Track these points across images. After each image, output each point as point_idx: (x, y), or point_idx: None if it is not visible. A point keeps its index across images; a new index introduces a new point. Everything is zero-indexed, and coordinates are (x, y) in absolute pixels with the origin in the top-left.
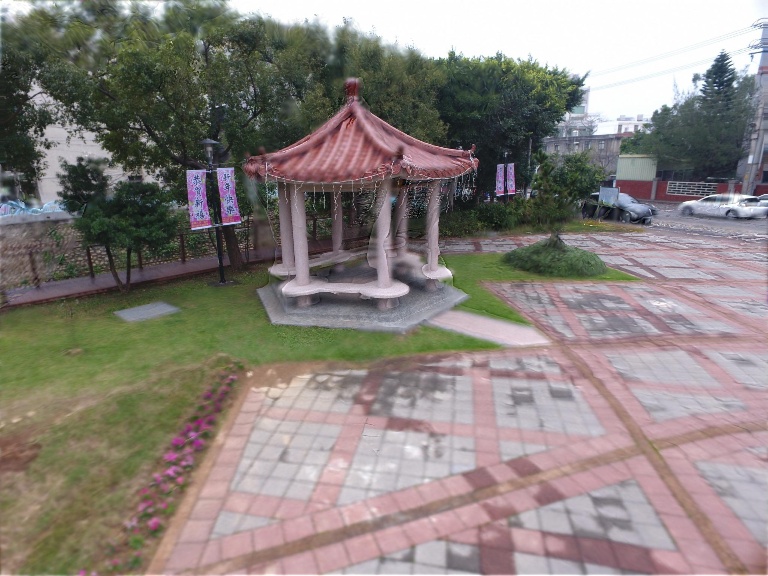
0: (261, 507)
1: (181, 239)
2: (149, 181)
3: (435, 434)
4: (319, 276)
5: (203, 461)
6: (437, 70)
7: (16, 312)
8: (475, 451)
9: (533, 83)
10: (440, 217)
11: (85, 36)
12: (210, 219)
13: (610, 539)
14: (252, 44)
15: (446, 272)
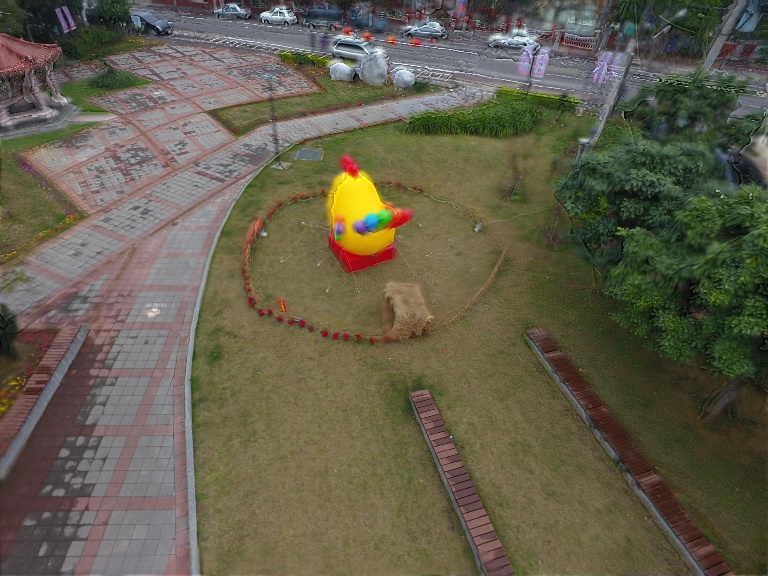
0: None
1: None
2: None
3: (91, 146)
4: (5, 112)
5: (31, 166)
6: None
7: None
8: None
9: None
10: None
11: None
12: None
13: None
14: None
15: (62, 98)
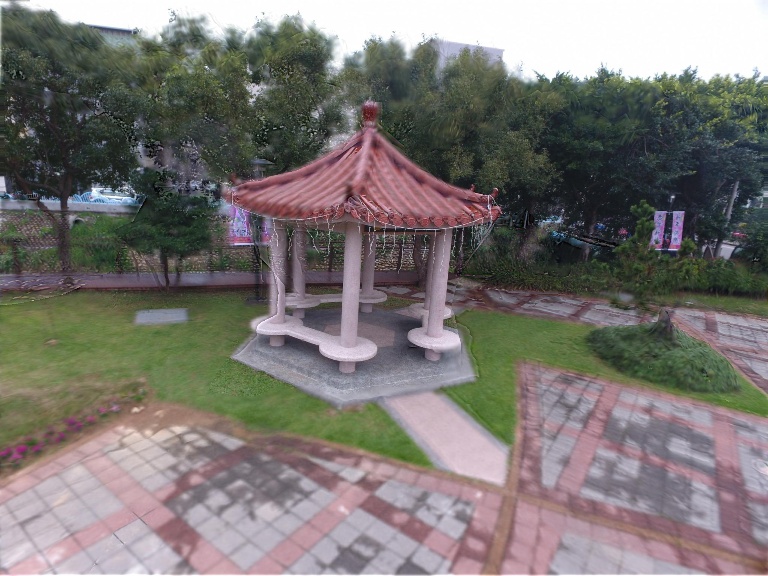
0: None
1: (220, 253)
2: (197, 195)
3: (180, 570)
4: (295, 317)
5: None
6: (553, 92)
7: (84, 294)
8: None
9: (717, 109)
10: (444, 274)
11: (163, 63)
12: None
13: None
14: (312, 67)
15: (452, 342)
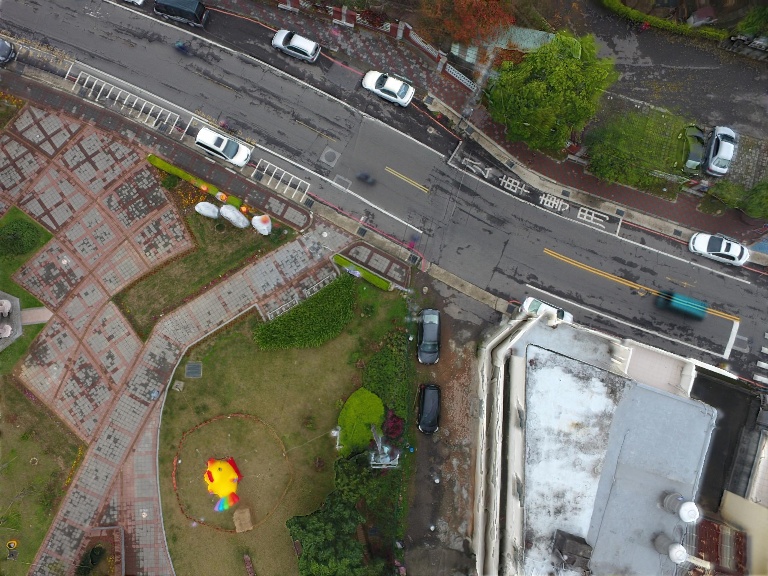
0: (48, 392)
1: None
2: None
3: (55, 363)
4: None
5: (34, 394)
6: None
7: None
8: (62, 362)
9: None
10: None
11: None
12: None
13: (83, 364)
14: None
15: (7, 304)
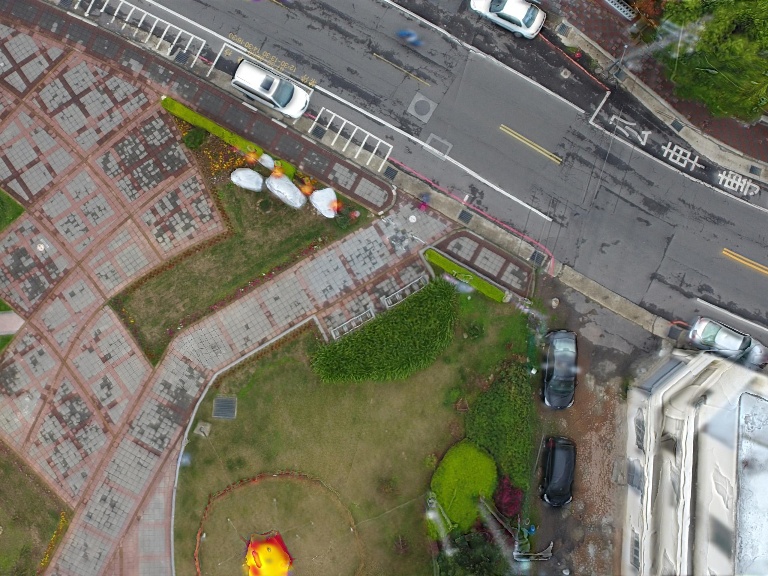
0: (17, 432)
1: None
2: None
3: (28, 391)
4: None
5: None
6: None
7: None
8: (38, 390)
9: None
10: None
11: None
12: None
13: (68, 395)
14: None
15: None
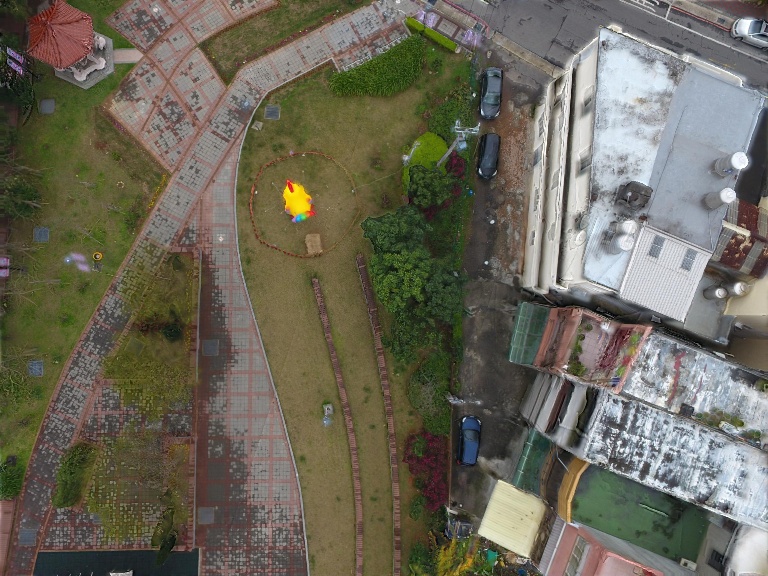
0: (136, 124)
1: None
2: None
3: (144, 99)
4: (82, 71)
5: (122, 125)
6: None
7: (23, 130)
8: (150, 98)
9: None
10: None
11: None
12: (20, 67)
13: (170, 102)
14: None
15: (102, 40)
